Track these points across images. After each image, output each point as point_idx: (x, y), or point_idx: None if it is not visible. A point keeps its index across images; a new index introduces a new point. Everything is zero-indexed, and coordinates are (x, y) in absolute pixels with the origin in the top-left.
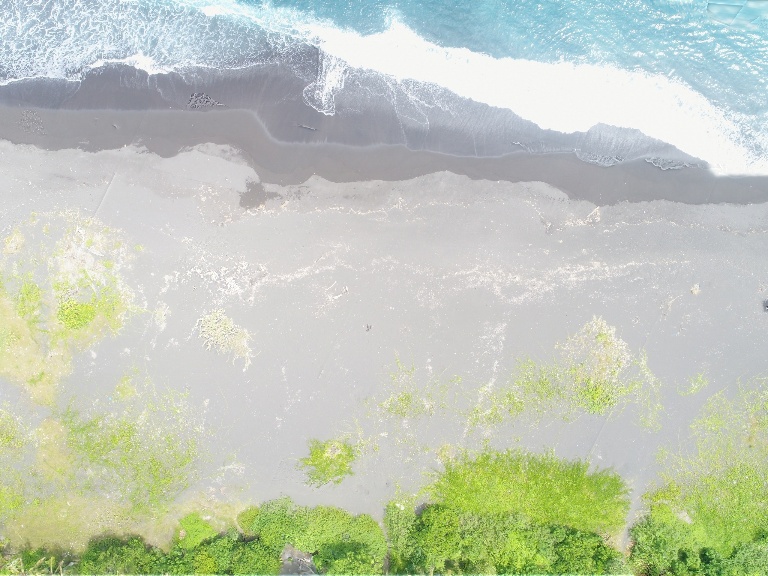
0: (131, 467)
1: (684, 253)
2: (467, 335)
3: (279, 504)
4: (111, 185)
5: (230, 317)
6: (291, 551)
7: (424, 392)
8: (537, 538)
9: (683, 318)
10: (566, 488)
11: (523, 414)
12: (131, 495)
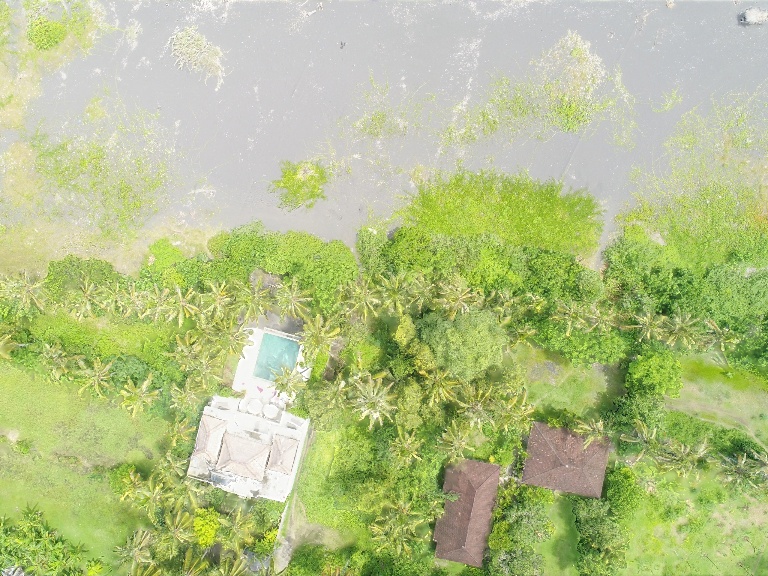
0: (100, 192)
1: None
2: (442, 52)
3: (250, 228)
4: None
5: (203, 34)
6: (262, 277)
7: (398, 111)
8: (510, 255)
9: (658, 32)
10: (539, 209)
11: (497, 133)
12: (100, 221)
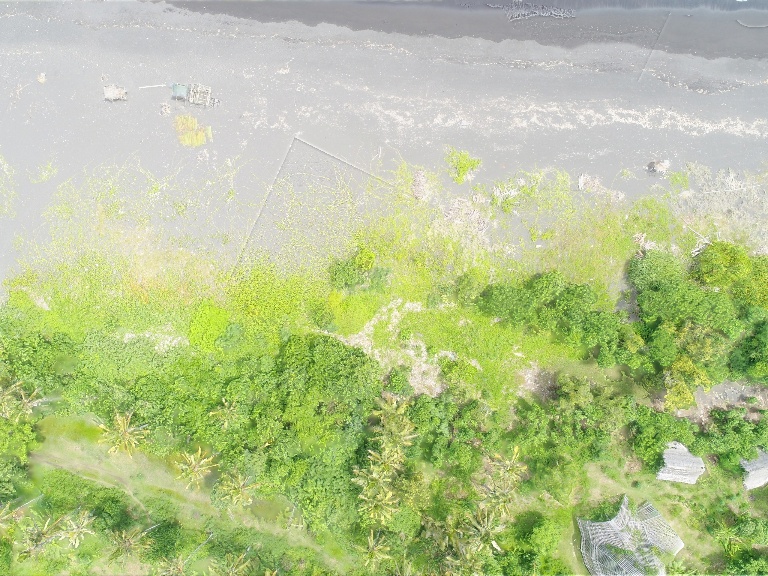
0: None
1: (37, 44)
2: None
3: None
4: None
5: None
6: None
7: None
8: None
9: (31, 106)
10: None
11: None
12: None
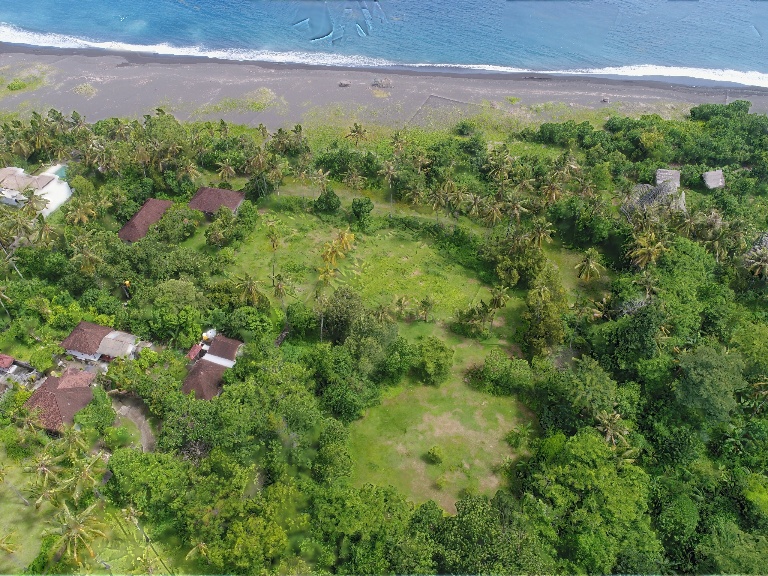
0: None
1: None
2: None
3: None
4: (61, 60)
5: None
6: None
7: None
8: None
9: None
10: None
11: None
12: None
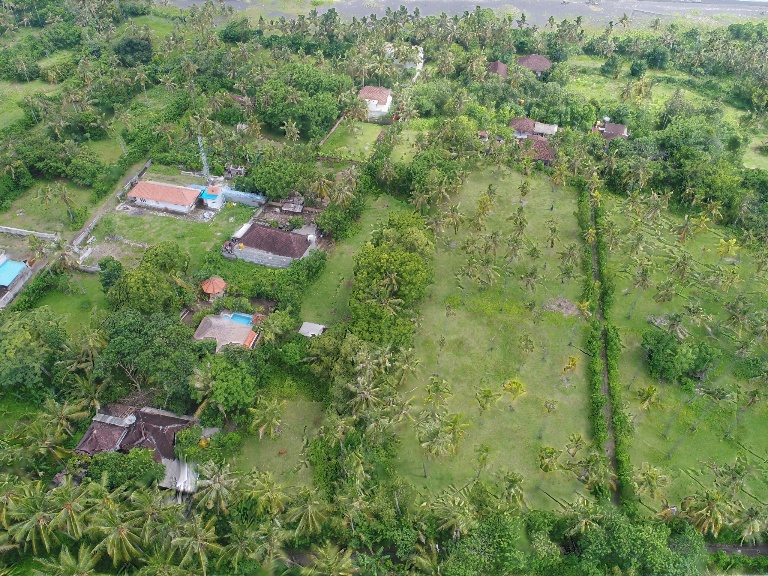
0: None
1: None
2: None
3: None
4: None
5: None
6: None
7: None
8: None
9: None
10: None
11: None
12: None
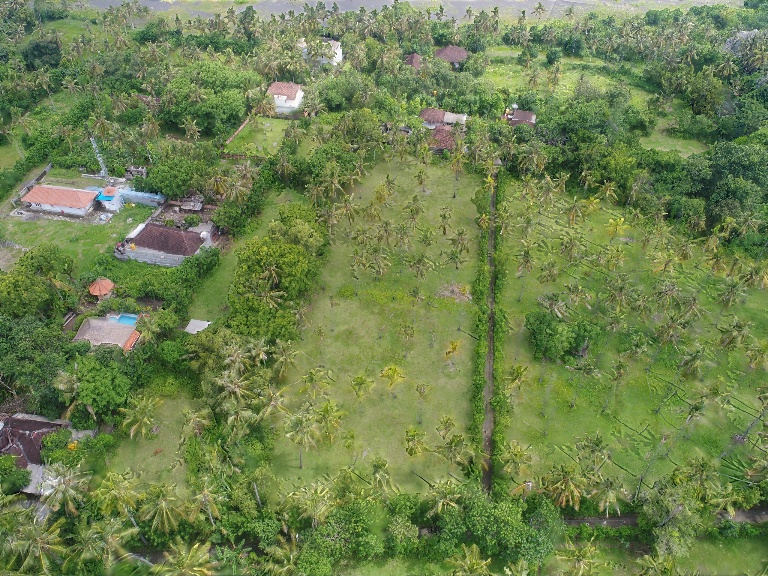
0: None
1: None
2: (386, 1)
3: None
4: None
5: None
6: None
7: None
8: None
9: None
10: None
11: None
12: None
